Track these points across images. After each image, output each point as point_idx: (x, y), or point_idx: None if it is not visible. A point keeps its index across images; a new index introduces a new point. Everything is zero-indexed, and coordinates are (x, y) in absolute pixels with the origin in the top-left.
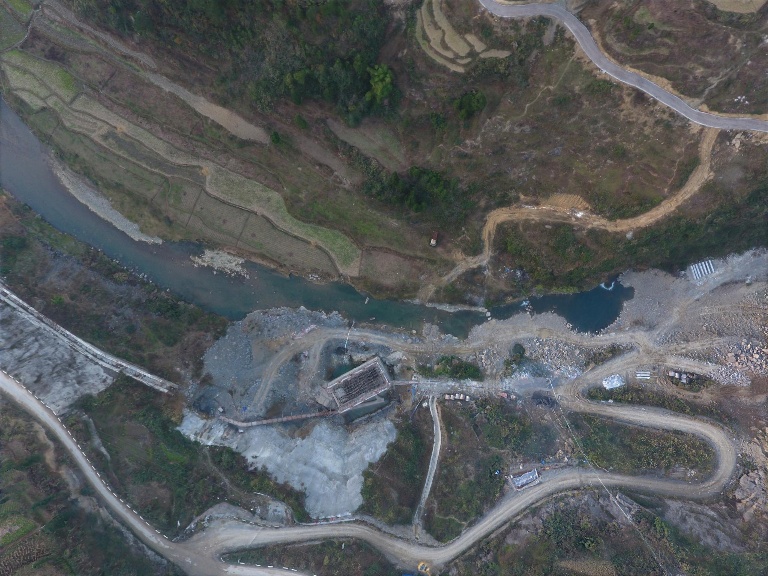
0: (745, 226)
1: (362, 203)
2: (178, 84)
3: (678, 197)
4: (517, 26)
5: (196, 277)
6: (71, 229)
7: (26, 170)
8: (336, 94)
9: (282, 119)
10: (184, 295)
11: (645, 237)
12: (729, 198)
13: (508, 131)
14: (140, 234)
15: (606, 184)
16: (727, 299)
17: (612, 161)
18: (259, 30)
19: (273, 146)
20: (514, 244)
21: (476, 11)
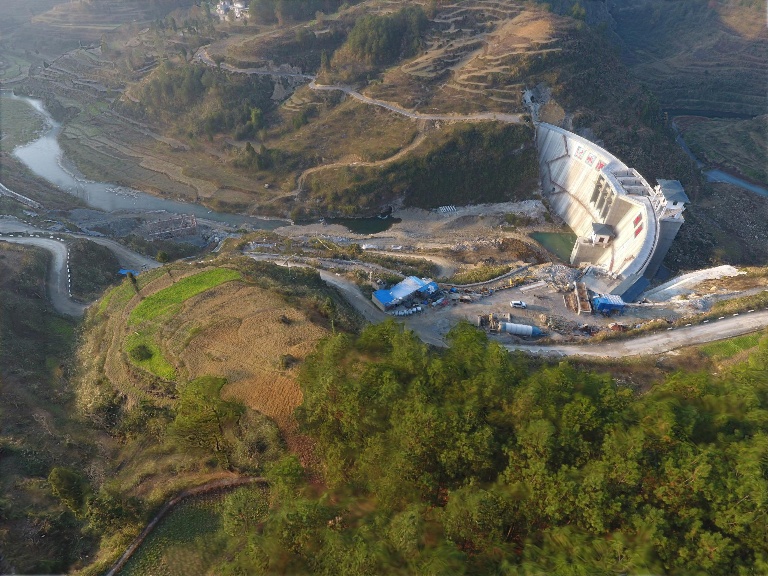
0: (461, 173)
1: (230, 171)
2: (154, 133)
3: (409, 148)
4: (326, 93)
5: (103, 196)
6: (44, 175)
7: (41, 156)
8: (233, 125)
9: (201, 139)
10: (88, 202)
11: (390, 164)
12: (436, 145)
13: (317, 128)
14: (84, 179)
15: (369, 146)
16: (469, 227)
17: (373, 138)
18: (204, 104)
19: (190, 151)
20: (315, 181)
21: (308, 89)
